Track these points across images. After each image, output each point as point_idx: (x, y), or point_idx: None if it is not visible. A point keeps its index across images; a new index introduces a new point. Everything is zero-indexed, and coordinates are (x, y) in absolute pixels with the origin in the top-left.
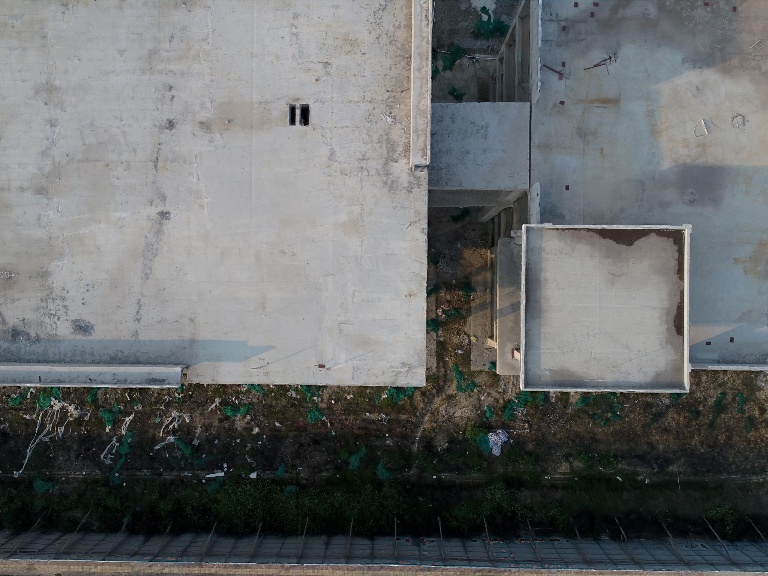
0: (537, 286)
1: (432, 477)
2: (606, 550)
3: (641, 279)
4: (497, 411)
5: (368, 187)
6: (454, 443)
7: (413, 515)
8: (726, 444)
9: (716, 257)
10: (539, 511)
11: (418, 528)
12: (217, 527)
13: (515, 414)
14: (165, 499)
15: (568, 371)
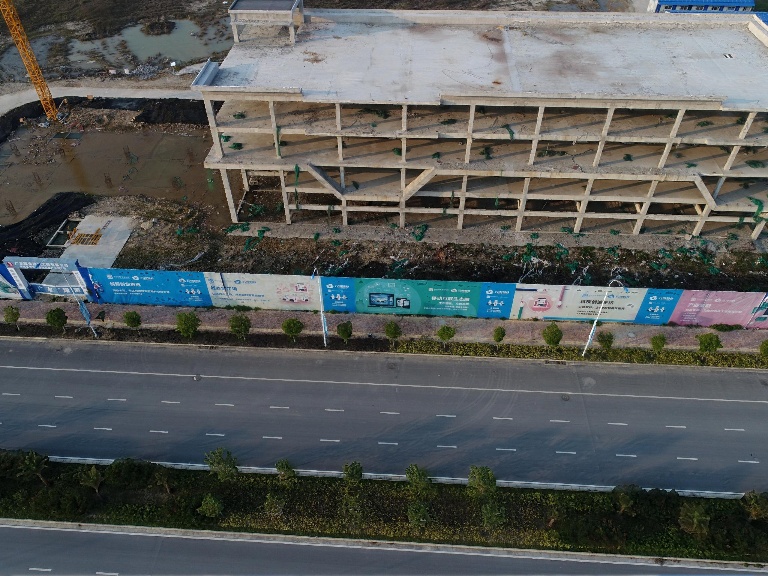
0: None
1: None
2: None
3: None
4: None
5: None
6: None
7: None
8: None
9: None
10: None
11: None
12: None
13: None
14: None
15: None
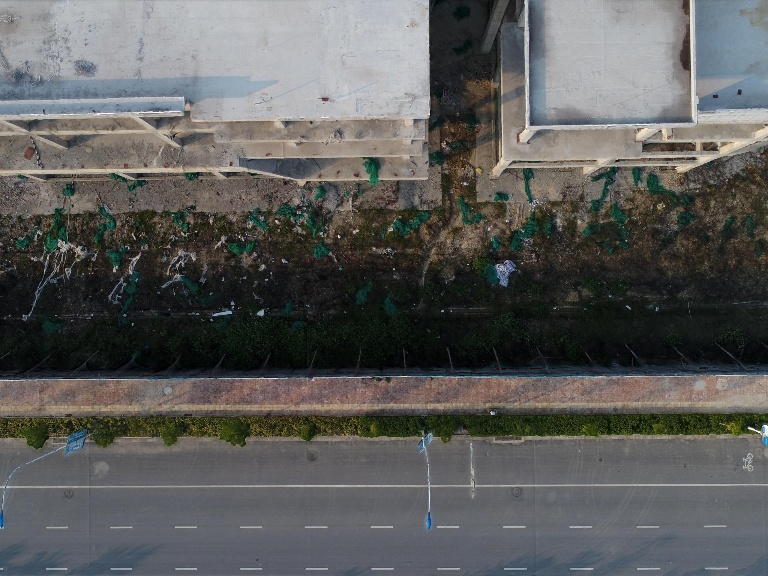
0: (541, 25)
1: (440, 311)
2: (617, 370)
3: (646, 15)
4: (504, 241)
5: None
6: (461, 275)
7: (422, 346)
8: (736, 268)
9: (722, 9)
10: (548, 340)
11: (427, 358)
12: (226, 361)
13: (522, 245)
14: (173, 337)
15: (574, 109)
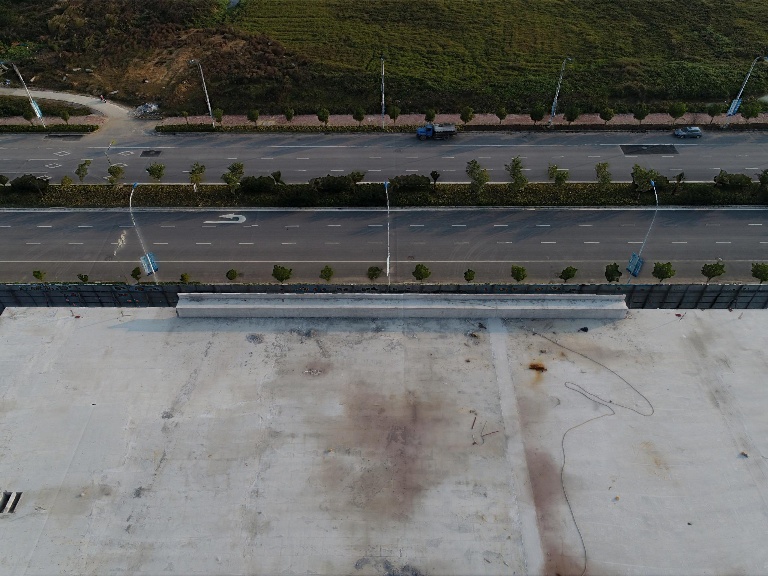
0: None
1: None
2: (1, 307)
3: None
4: None
5: None
6: None
7: None
8: None
9: None
10: None
11: None
12: None
13: None
14: None
15: None
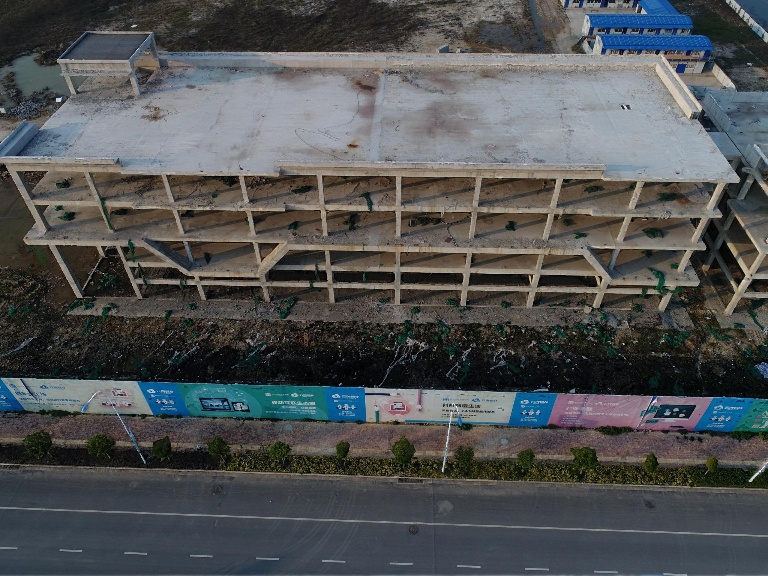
0: None
1: None
2: None
3: None
4: (754, 351)
5: (671, 124)
6: (730, 371)
7: None
8: None
9: None
10: None
11: None
12: None
13: None
14: None
15: None
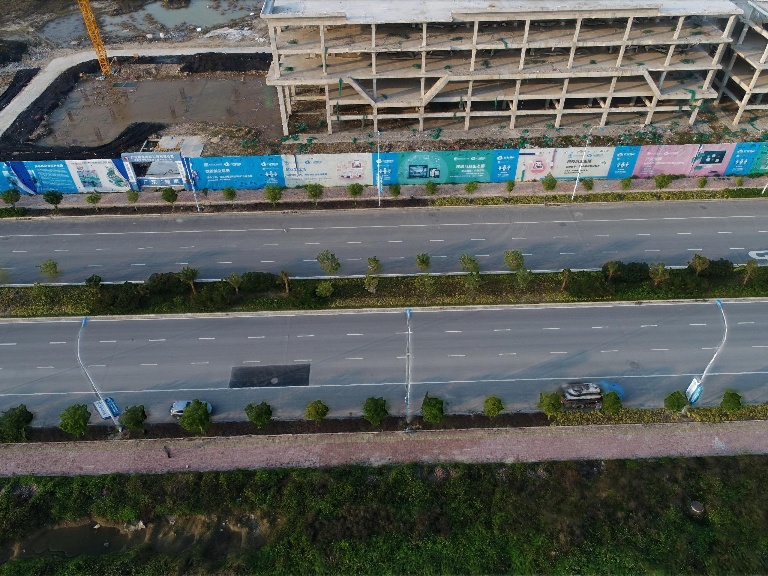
0: None
1: None
2: None
3: None
4: (755, 140)
5: None
6: None
7: None
8: None
9: None
10: None
11: None
12: None
13: None
14: None
15: None
